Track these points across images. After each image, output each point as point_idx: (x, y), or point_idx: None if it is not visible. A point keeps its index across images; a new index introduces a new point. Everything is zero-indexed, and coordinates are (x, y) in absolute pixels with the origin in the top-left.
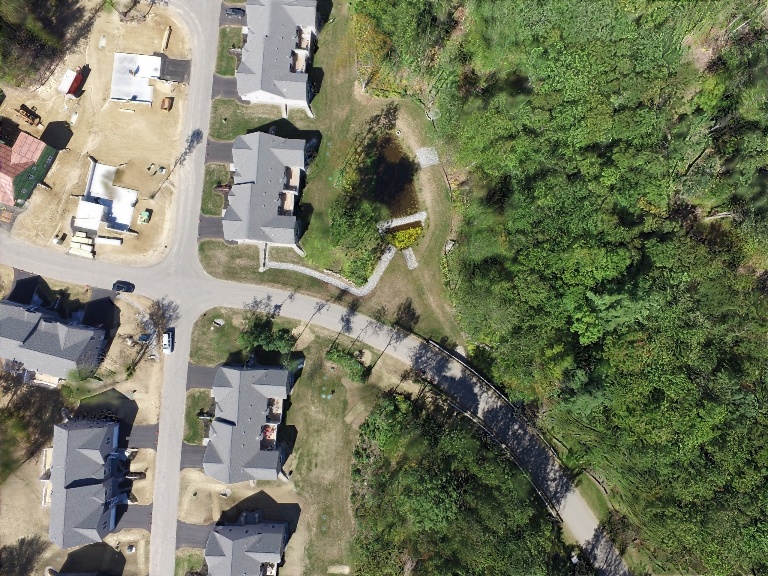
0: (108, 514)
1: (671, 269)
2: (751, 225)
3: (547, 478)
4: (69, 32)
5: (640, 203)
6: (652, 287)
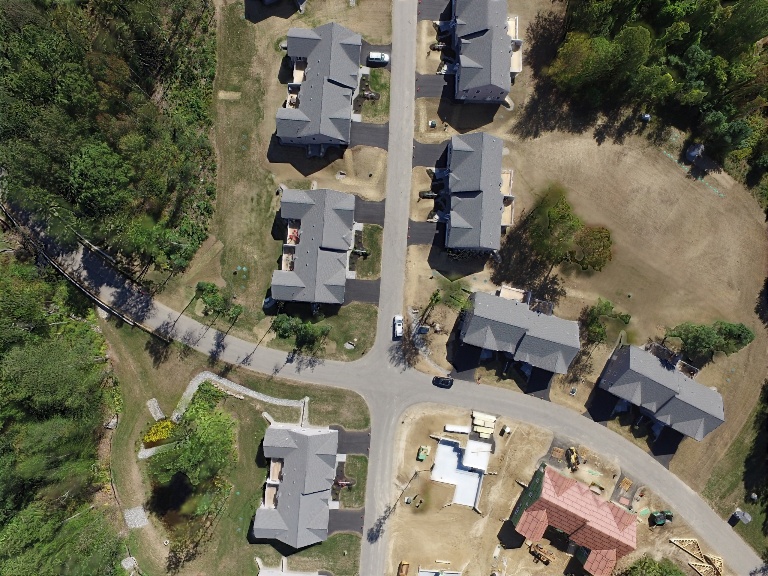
0: None
1: None
2: None
3: None
4: None
5: None
6: None
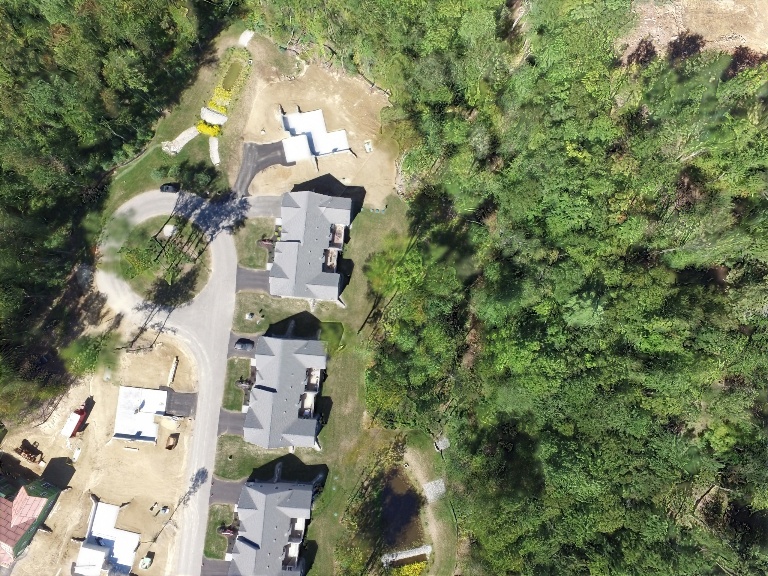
0: None
1: None
2: None
3: None
4: (74, 363)
5: None
6: None
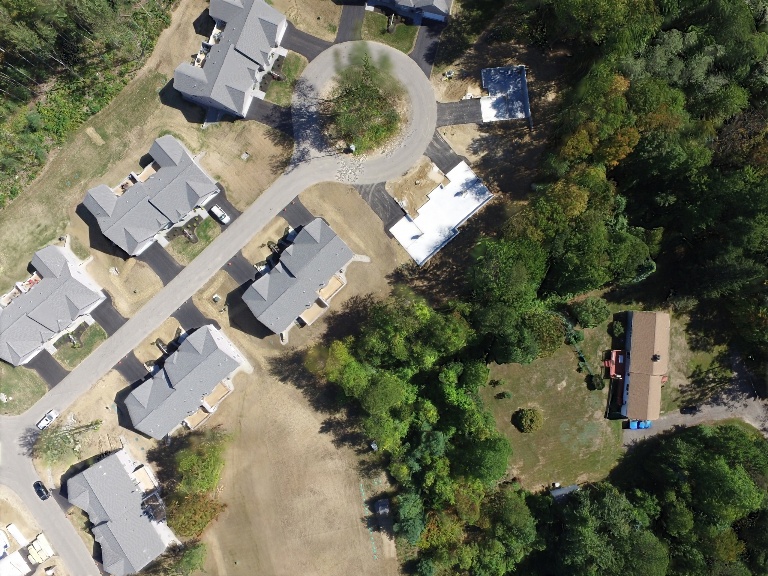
0: None
1: None
2: None
3: None
4: None
5: None
6: None
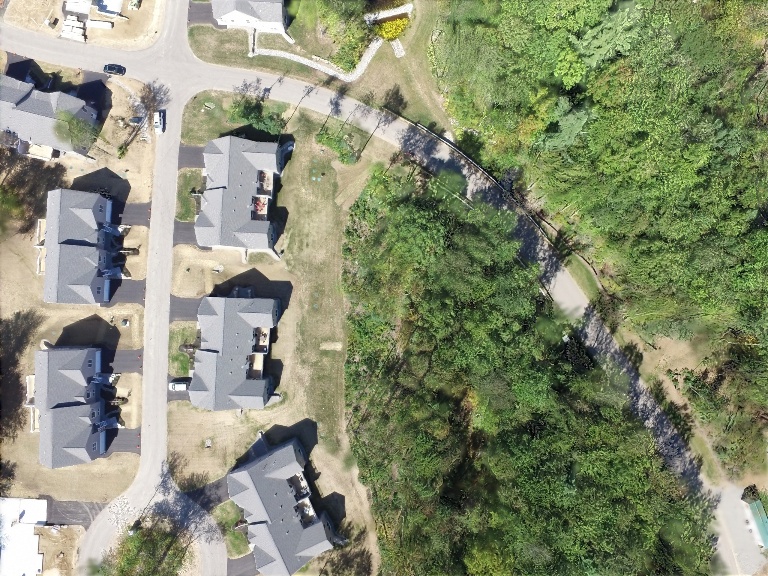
0: (102, 282)
1: (652, 10)
2: (734, 8)
3: (537, 258)
4: None
5: None
6: None
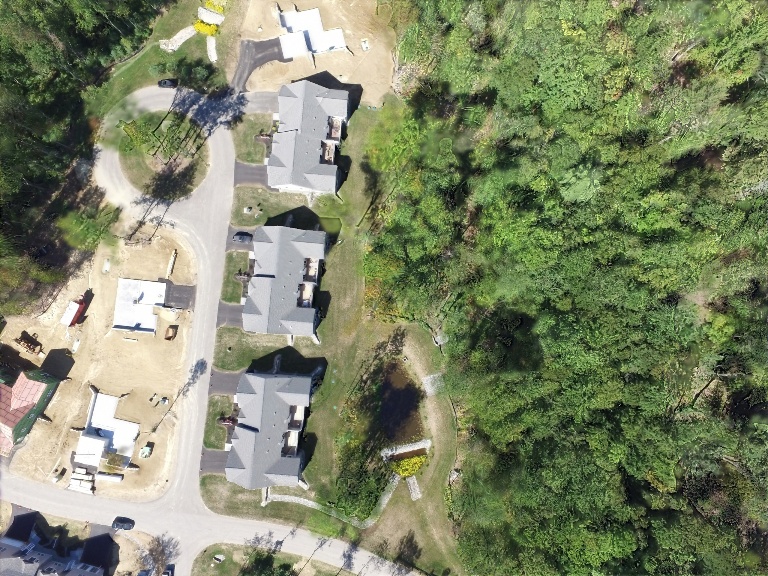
0: None
1: (677, 552)
2: (757, 462)
3: None
4: (72, 256)
5: (648, 478)
6: (658, 571)
